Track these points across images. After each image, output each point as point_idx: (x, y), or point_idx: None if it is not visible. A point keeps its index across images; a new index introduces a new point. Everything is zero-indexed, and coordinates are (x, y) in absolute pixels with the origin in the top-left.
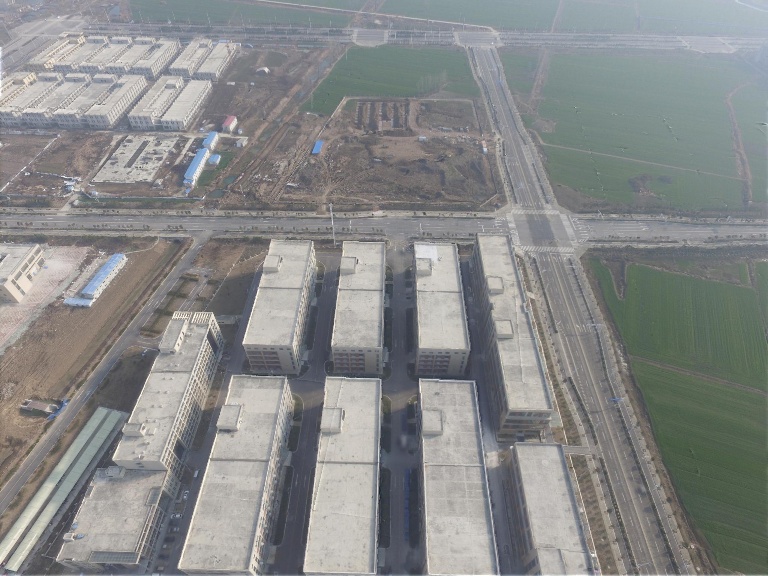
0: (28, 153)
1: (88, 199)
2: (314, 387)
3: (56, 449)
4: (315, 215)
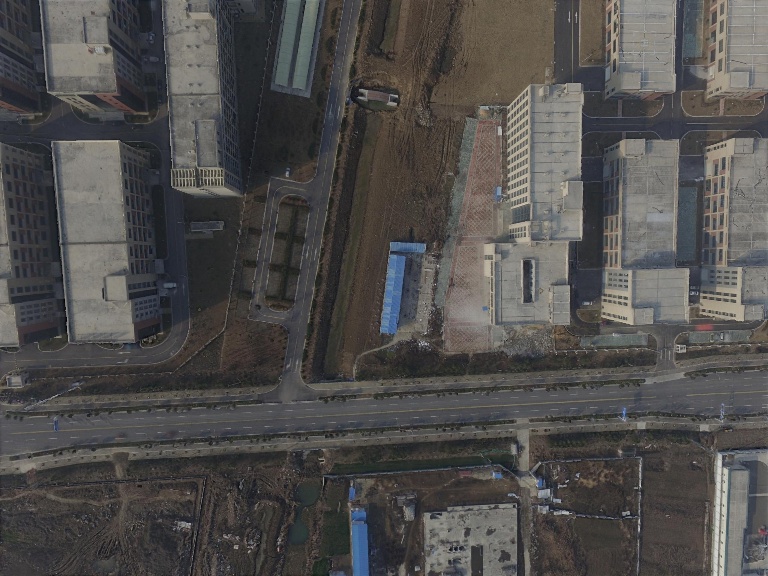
0: (658, 571)
1: (502, 461)
2: (64, 132)
3: (329, 43)
4: (130, 452)
